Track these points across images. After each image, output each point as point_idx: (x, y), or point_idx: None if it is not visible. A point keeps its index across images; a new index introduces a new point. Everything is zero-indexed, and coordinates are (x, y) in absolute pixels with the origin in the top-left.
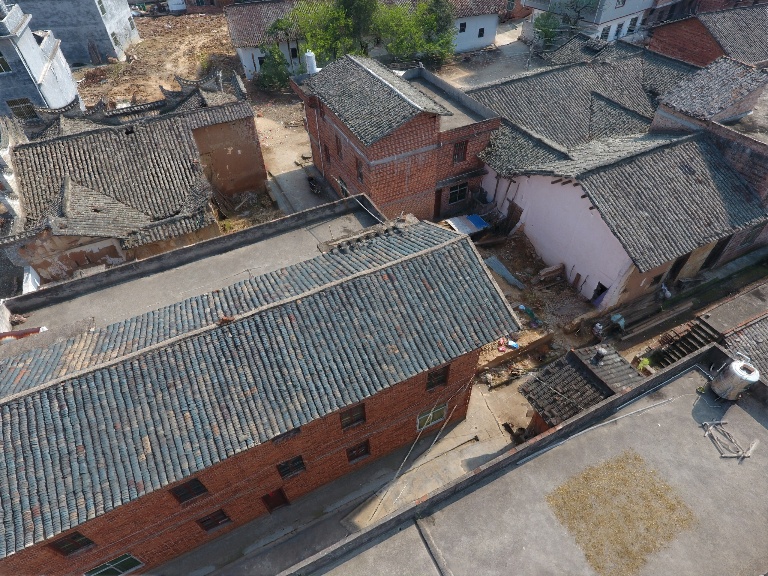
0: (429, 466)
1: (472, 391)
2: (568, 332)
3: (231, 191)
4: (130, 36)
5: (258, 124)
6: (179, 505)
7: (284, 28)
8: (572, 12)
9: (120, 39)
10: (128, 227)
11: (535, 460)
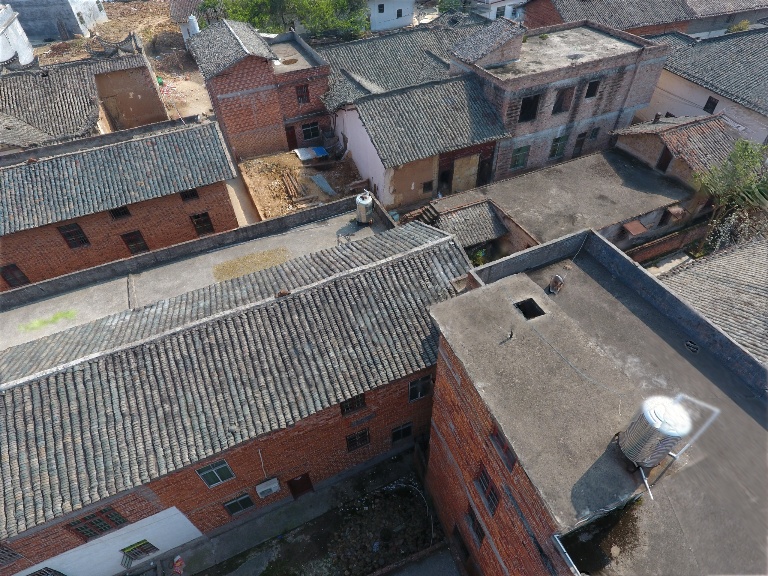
0: None
1: None
2: None
3: None
4: (97, 17)
5: (183, 85)
6: (9, 287)
7: (211, 5)
8: None
9: (86, 18)
10: (31, 141)
11: (220, 251)
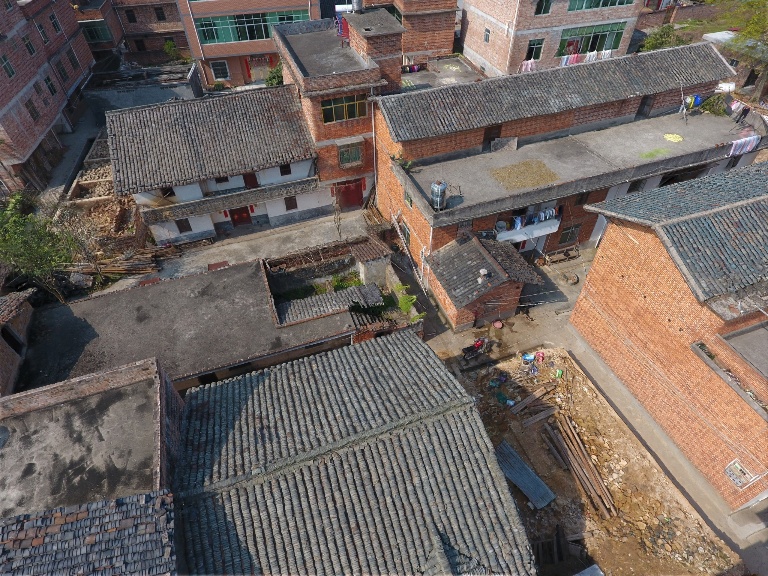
0: None
1: None
2: None
3: None
4: None
5: None
6: None
7: None
8: None
9: None
10: None
11: None
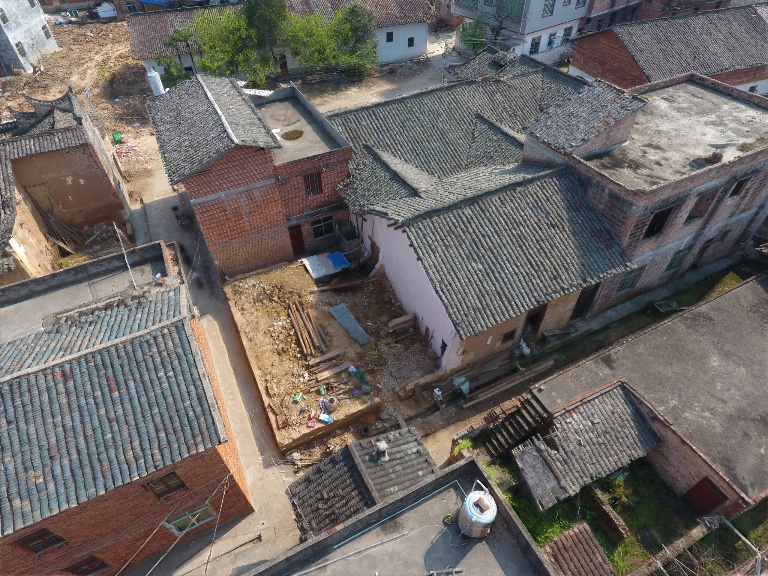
0: (193, 575)
1: (274, 474)
2: (402, 398)
3: (81, 223)
4: (44, 45)
5: (147, 143)
6: None
7: (182, 39)
8: (494, 22)
9: (29, 49)
10: None
11: None
